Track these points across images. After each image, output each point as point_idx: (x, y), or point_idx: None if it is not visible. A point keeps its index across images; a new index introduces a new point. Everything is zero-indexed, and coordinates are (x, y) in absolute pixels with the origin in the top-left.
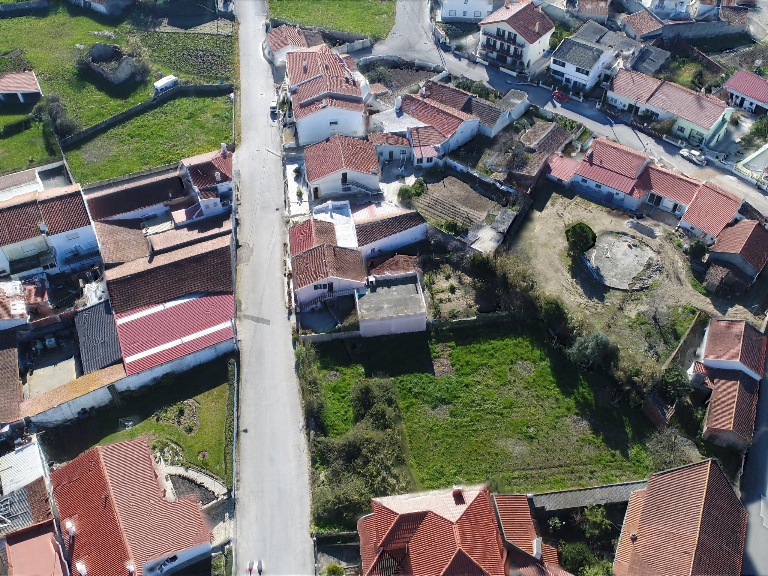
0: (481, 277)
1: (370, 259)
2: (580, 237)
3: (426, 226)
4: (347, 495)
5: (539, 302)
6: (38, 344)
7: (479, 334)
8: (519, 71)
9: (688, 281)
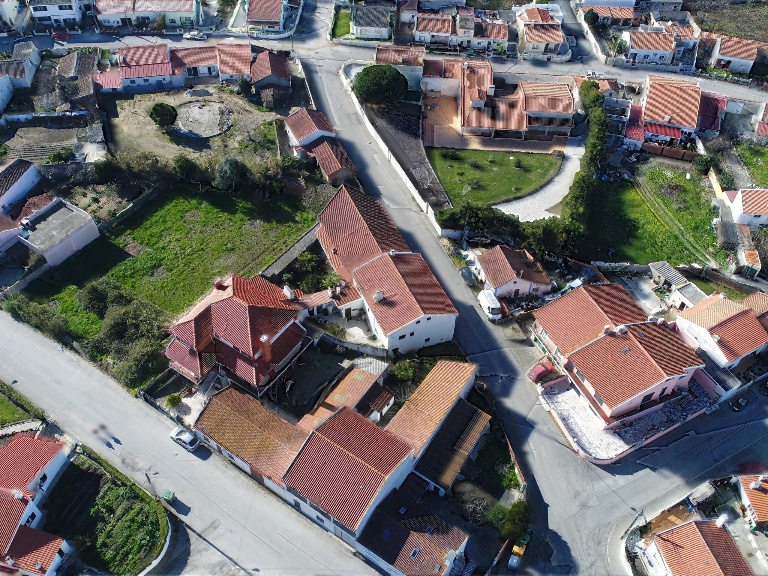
0: (112, 178)
1: (7, 214)
2: (164, 113)
3: (35, 167)
4: (141, 353)
5: (170, 167)
6: None
7: (143, 215)
8: (7, 31)
9: (254, 109)
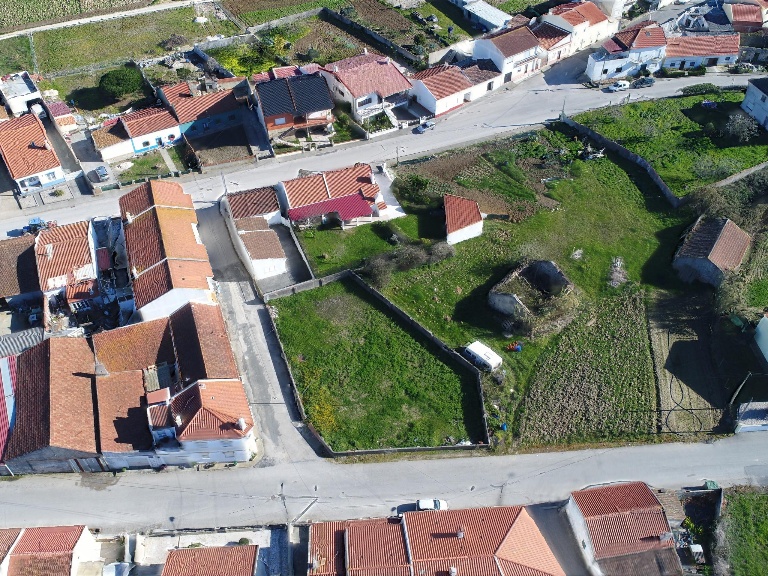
0: None
1: None
2: None
3: None
4: None
5: None
6: (35, 310)
7: None
8: None
9: None
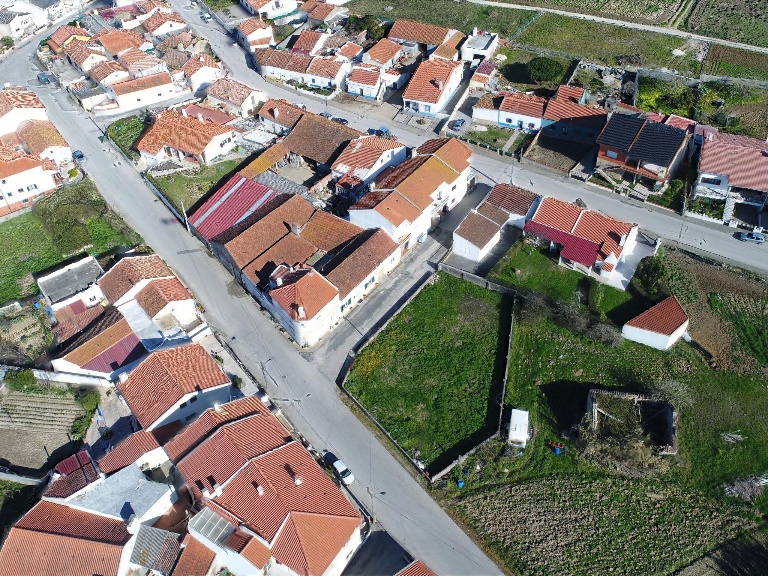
0: None
1: None
2: None
3: None
4: None
5: None
6: None
7: None
8: None
9: None
